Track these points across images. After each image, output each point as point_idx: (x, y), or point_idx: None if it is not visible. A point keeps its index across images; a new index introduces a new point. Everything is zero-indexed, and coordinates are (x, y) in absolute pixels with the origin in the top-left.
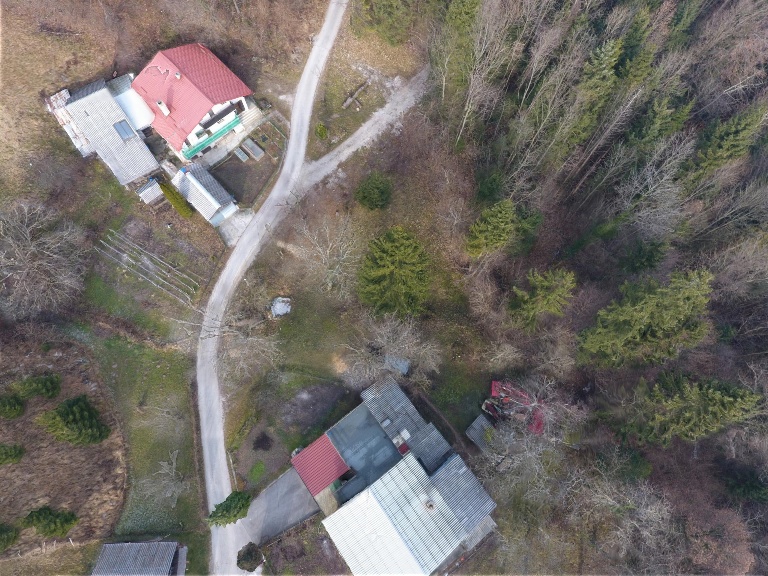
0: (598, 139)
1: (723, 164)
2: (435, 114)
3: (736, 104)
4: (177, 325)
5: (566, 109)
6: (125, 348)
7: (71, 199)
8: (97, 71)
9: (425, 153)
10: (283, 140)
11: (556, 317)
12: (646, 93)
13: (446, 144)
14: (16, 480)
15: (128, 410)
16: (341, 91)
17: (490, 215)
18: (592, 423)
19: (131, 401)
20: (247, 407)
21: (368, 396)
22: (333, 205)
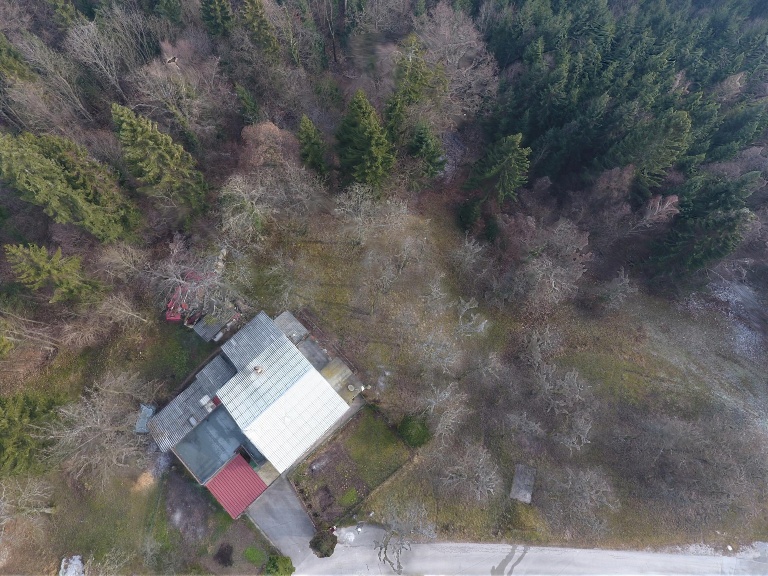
0: None
1: None
2: None
3: None
4: None
5: None
6: None
7: None
8: None
9: None
10: None
11: None
12: None
13: None
14: None
15: None
16: None
17: None
18: None
19: None
20: None
21: (166, 444)
22: None
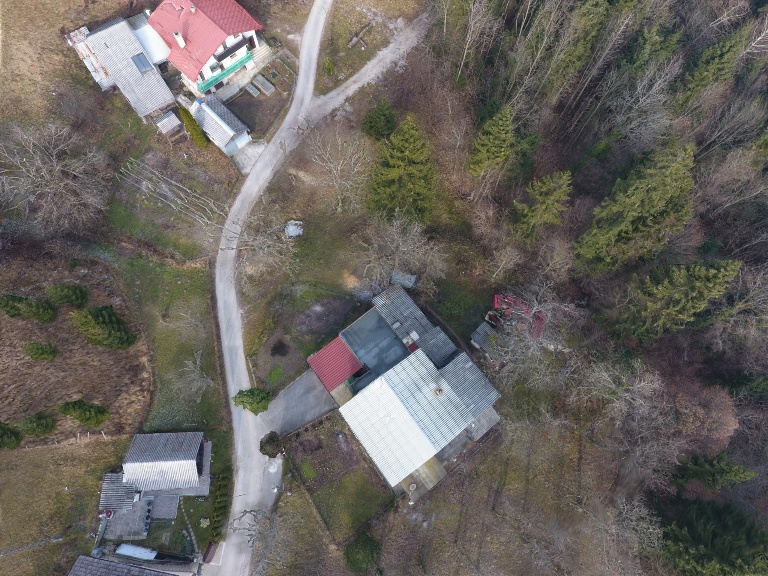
0: (592, 69)
1: (709, 84)
2: (437, 47)
3: (722, 35)
4: (196, 245)
5: (561, 33)
6: (147, 266)
7: (91, 131)
8: (114, 10)
9: (428, 89)
10: (292, 76)
11: (554, 230)
12: (637, 22)
13: (447, 82)
14: (51, 377)
15: (152, 322)
16: (347, 31)
17: (492, 125)
18: (589, 330)
19: (154, 313)
20: (264, 318)
21: (379, 302)
22: (341, 137)
